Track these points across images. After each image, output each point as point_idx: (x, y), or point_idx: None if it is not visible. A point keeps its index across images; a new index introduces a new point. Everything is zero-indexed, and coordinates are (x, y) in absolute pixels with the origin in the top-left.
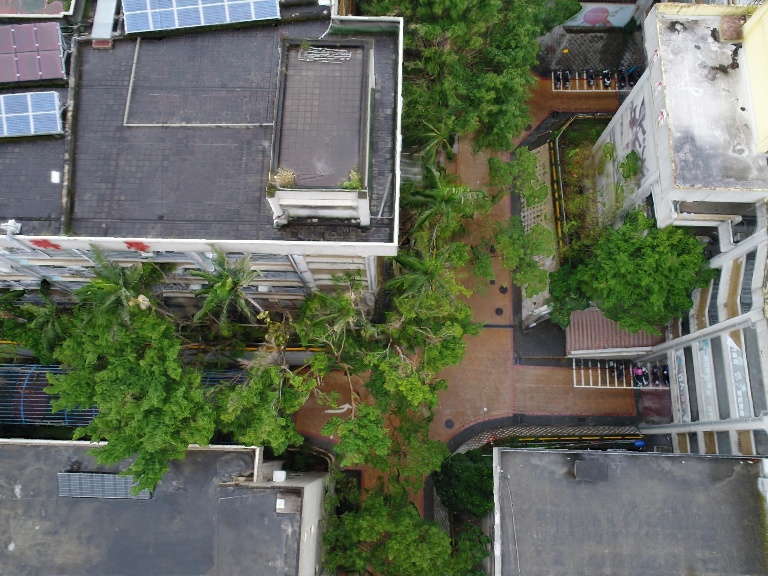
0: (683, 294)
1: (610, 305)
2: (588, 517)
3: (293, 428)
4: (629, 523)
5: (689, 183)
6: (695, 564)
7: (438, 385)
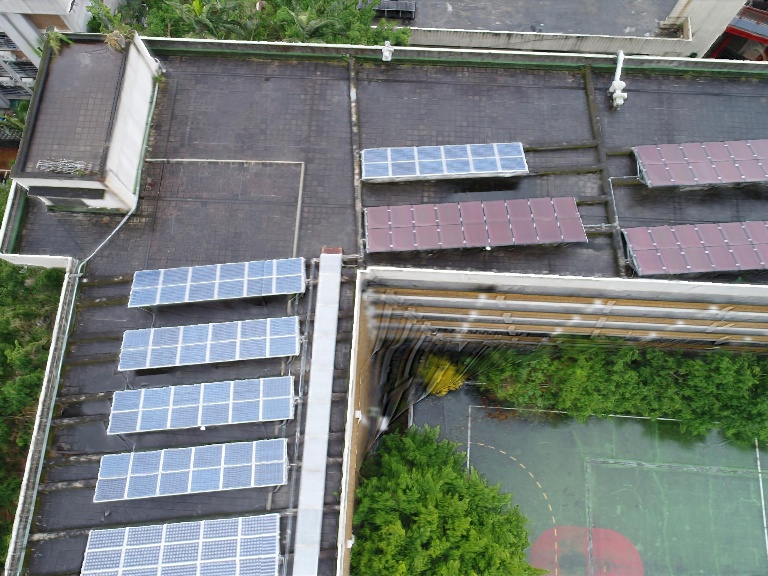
0: None
1: None
2: None
3: None
4: None
5: None
6: None
7: None
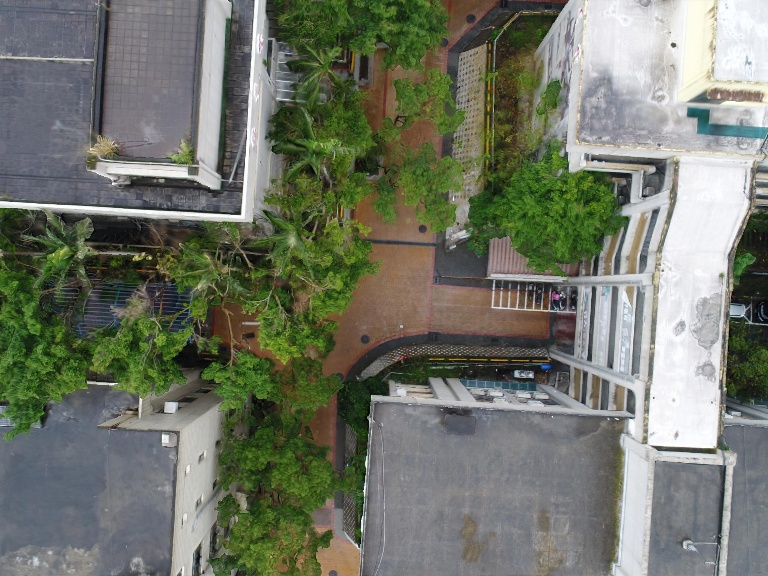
0: (590, 240)
1: (518, 245)
2: (454, 463)
3: (176, 369)
4: (492, 470)
5: (596, 135)
6: (548, 507)
7: (327, 328)
